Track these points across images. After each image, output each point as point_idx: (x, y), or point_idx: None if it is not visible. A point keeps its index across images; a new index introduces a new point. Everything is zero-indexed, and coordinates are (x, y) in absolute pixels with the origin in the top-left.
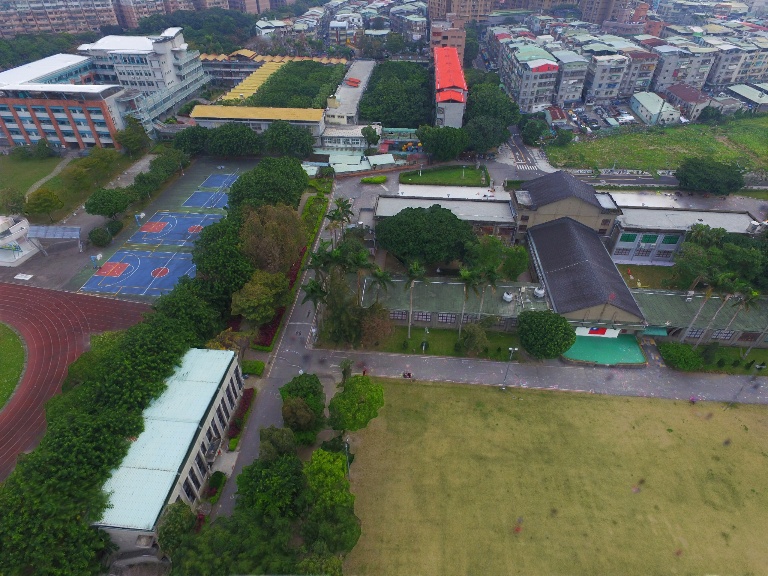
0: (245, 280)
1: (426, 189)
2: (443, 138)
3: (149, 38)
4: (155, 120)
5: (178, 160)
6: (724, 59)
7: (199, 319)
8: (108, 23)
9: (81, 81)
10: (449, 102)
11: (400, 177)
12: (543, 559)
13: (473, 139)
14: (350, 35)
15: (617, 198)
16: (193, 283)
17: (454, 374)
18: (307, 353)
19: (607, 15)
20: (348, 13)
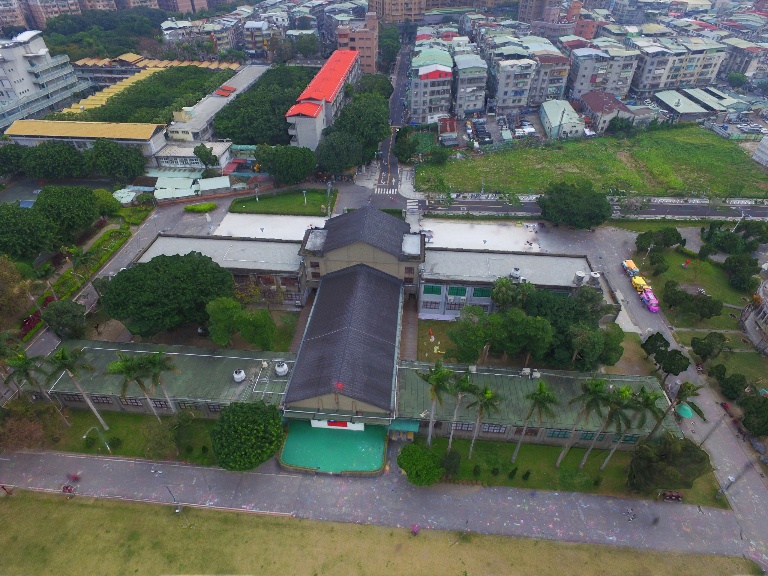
0: None
1: (255, 219)
2: (278, 160)
3: None
4: None
5: None
6: (649, 63)
7: None
8: (12, 24)
9: None
10: (299, 117)
11: (231, 204)
12: None
13: (324, 159)
14: (267, 36)
15: (469, 230)
16: None
17: (130, 486)
18: None
19: (542, 14)
20: (275, 12)
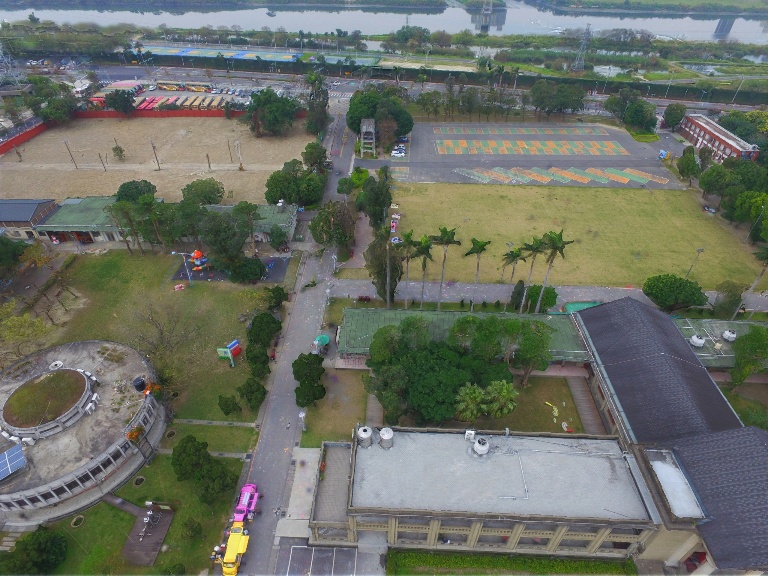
0: None
1: None
2: None
3: None
4: None
5: None
6: None
7: None
8: None
9: None
10: None
11: None
12: None
13: None
14: None
15: None
16: None
17: None
18: None
19: None
20: None
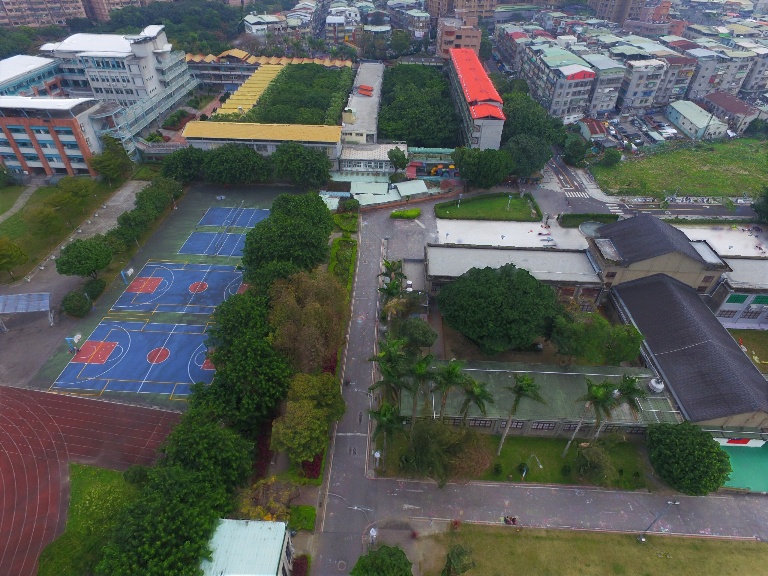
0: (283, 389)
1: (469, 225)
2: (486, 164)
3: (127, 38)
4: (137, 138)
5: (169, 192)
6: (761, 64)
7: (227, 461)
8: (75, 15)
9: (45, 88)
10: (487, 119)
11: (436, 210)
12: None
13: (516, 162)
14: (349, 32)
15: (690, 235)
16: (212, 396)
17: (571, 515)
18: (369, 486)
19: (624, 13)
20: (343, 7)
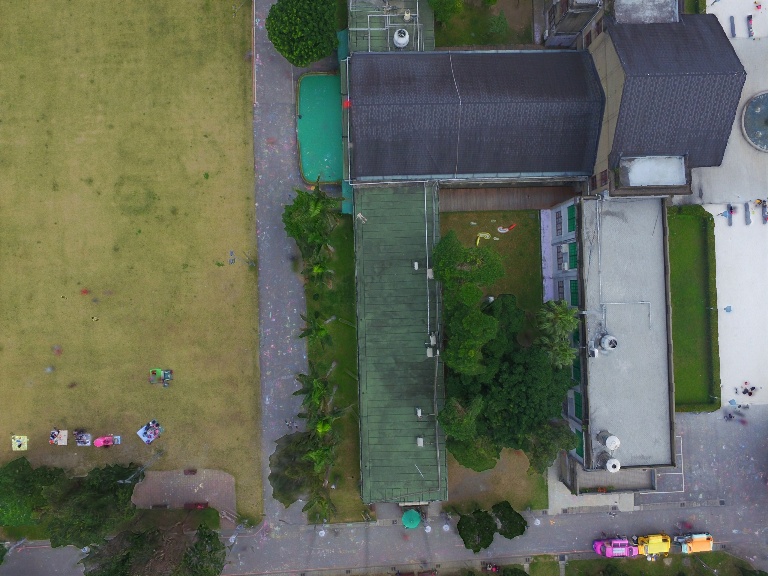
0: None
1: None
2: None
3: None
4: None
5: None
6: None
7: None
8: None
9: None
10: None
11: None
12: (51, 7)
13: None
14: None
15: None
16: None
17: None
18: None
19: None
20: None
